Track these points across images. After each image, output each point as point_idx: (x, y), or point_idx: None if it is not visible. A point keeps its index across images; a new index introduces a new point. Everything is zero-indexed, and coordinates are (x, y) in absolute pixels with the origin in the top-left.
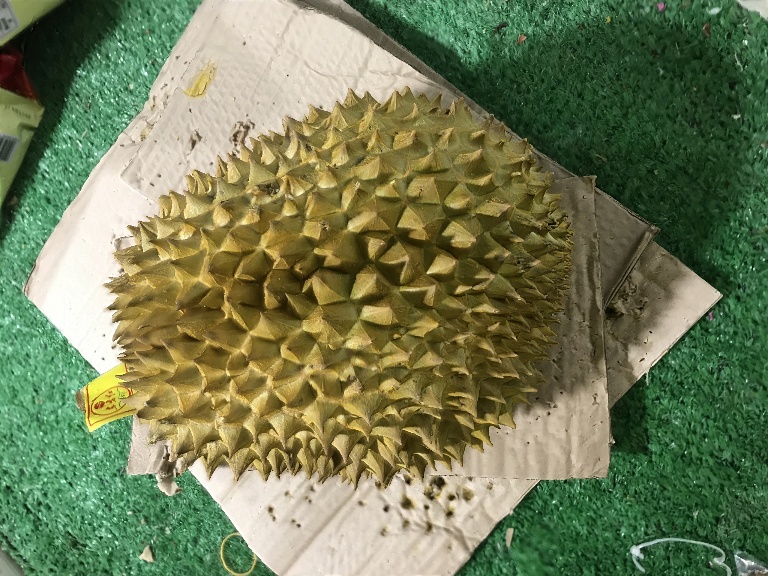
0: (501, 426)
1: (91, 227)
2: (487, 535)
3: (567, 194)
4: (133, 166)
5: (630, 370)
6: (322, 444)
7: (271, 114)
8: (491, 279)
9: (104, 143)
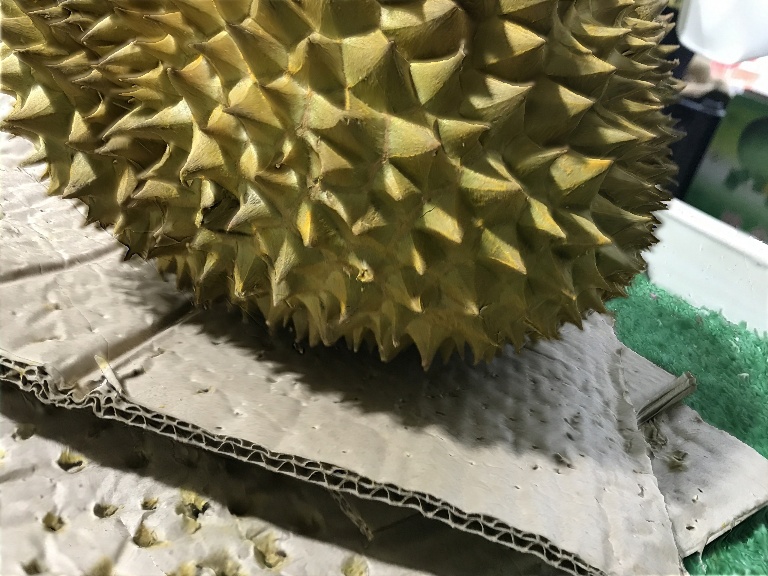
0: (460, 451)
1: None
2: None
3: None
4: None
5: None
6: None
7: None
8: (661, 2)
9: None
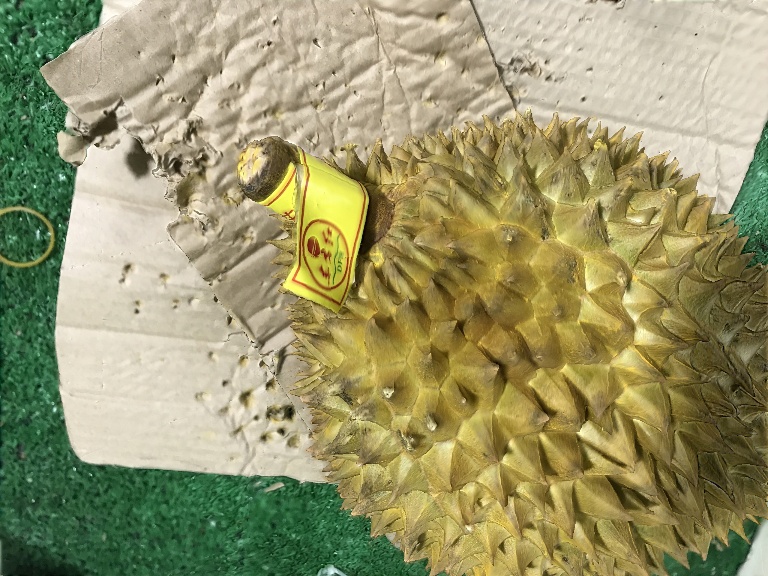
0: None
1: None
2: (266, 476)
3: None
4: None
5: None
6: (456, 574)
7: (641, 28)
8: None
9: None
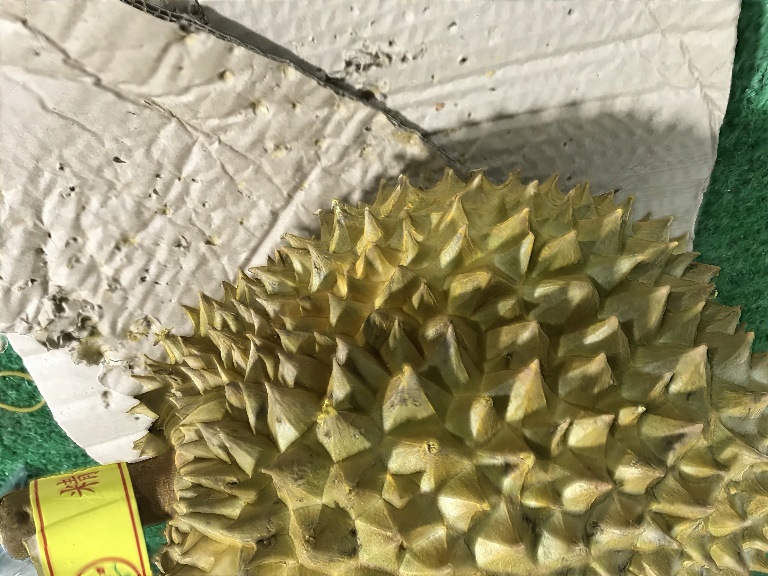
0: None
1: None
2: None
3: None
4: None
5: None
6: None
7: None
8: None
9: None
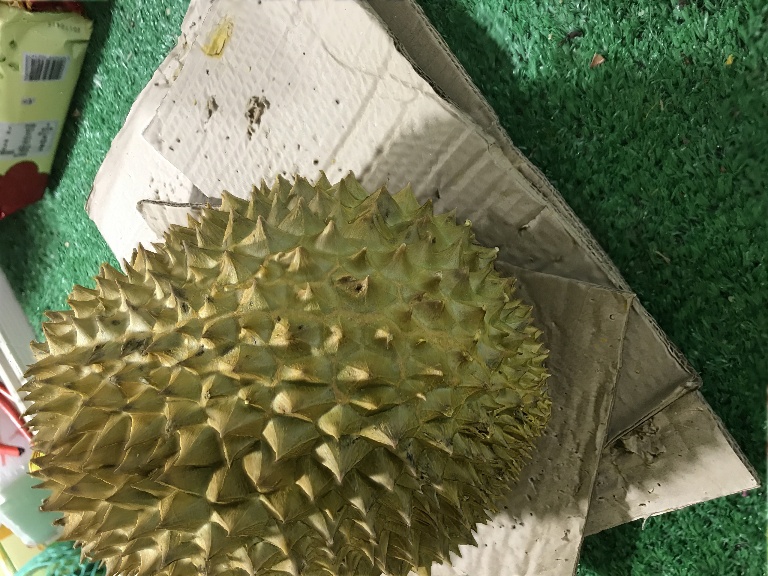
0: None
1: (133, 165)
2: None
3: (591, 307)
4: (153, 126)
5: (626, 509)
6: None
7: (286, 96)
8: None
9: (146, 72)
